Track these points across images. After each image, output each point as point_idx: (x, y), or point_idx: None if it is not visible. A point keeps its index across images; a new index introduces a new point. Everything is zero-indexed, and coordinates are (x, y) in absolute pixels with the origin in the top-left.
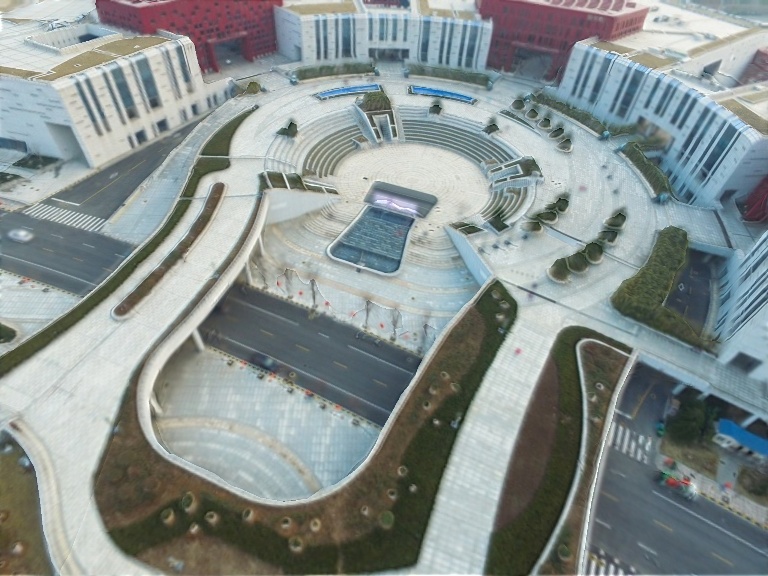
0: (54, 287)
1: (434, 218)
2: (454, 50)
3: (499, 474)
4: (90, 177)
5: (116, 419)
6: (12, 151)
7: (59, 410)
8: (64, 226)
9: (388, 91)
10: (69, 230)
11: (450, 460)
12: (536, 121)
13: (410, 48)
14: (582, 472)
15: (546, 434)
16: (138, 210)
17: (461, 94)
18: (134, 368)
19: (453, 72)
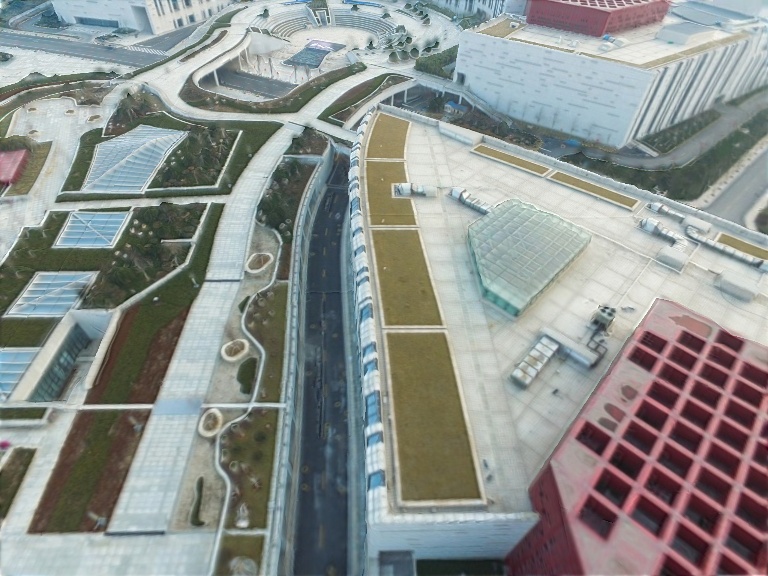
0: None
1: (342, 52)
2: None
3: (336, 98)
4: (154, 38)
5: (185, 83)
6: (110, 28)
7: (162, 82)
8: (145, 53)
9: (329, 2)
10: (148, 54)
11: (318, 95)
12: (416, 14)
13: None
14: None
15: None
16: None
17: (375, 3)
18: (190, 74)
19: None
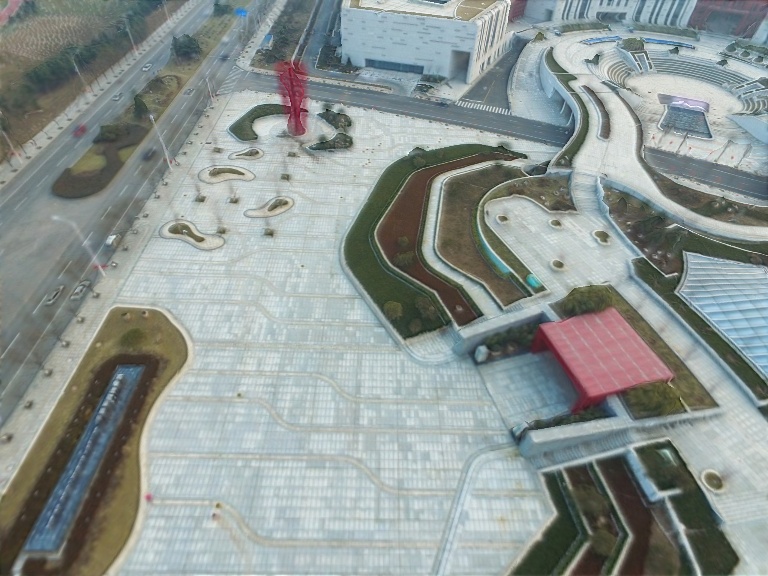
0: (519, 138)
1: (715, 113)
2: (663, 13)
3: None
4: (472, 89)
5: (650, 175)
6: (410, 73)
7: (616, 172)
8: (488, 112)
9: None
10: (494, 114)
11: None
12: (749, 59)
13: (628, 12)
14: None
15: None
16: (522, 105)
17: (681, 43)
18: (637, 159)
19: (667, 28)
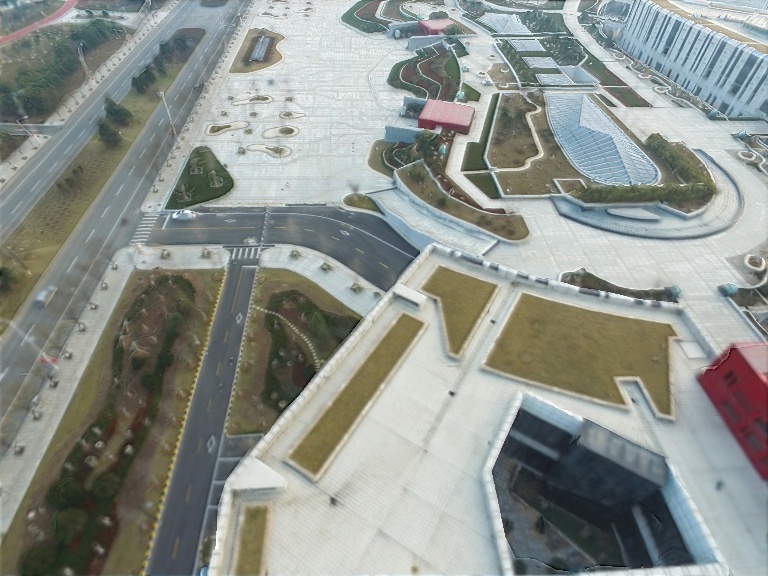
0: None
1: None
2: None
3: (578, 3)
4: None
5: None
6: None
7: None
8: None
9: None
10: None
11: (565, 2)
12: None
13: None
14: (598, 2)
15: (588, 0)
16: None
17: None
18: None
19: None
